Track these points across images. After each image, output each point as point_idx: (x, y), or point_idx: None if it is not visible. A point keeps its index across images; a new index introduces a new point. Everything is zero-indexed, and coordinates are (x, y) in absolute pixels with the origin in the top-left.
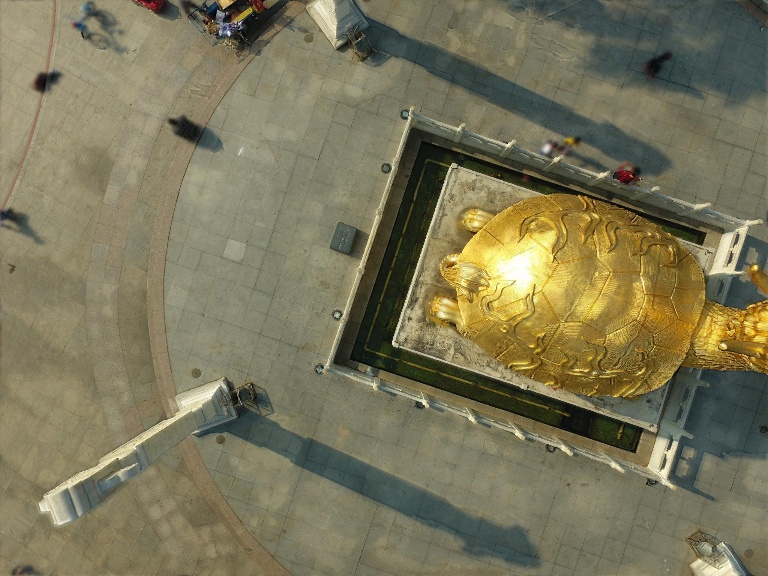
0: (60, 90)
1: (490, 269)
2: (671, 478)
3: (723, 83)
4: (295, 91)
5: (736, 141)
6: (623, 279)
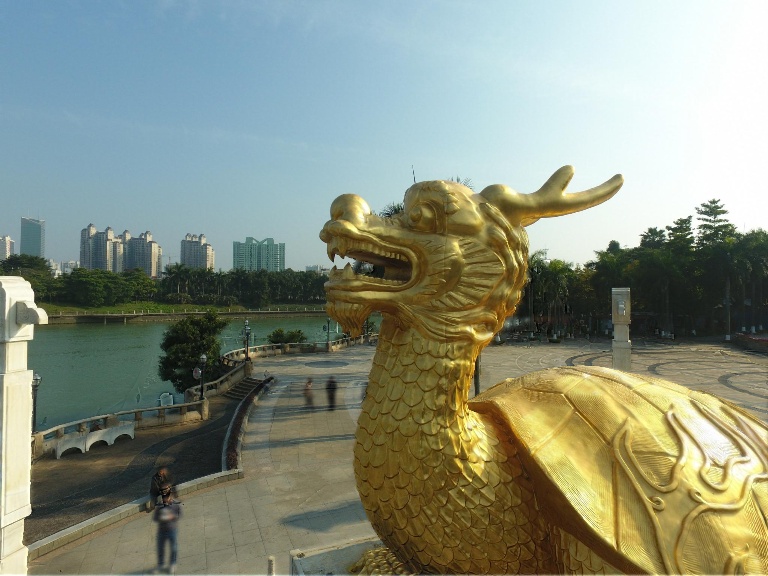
0: None
1: None
2: None
3: None
4: None
5: None
6: (633, 378)
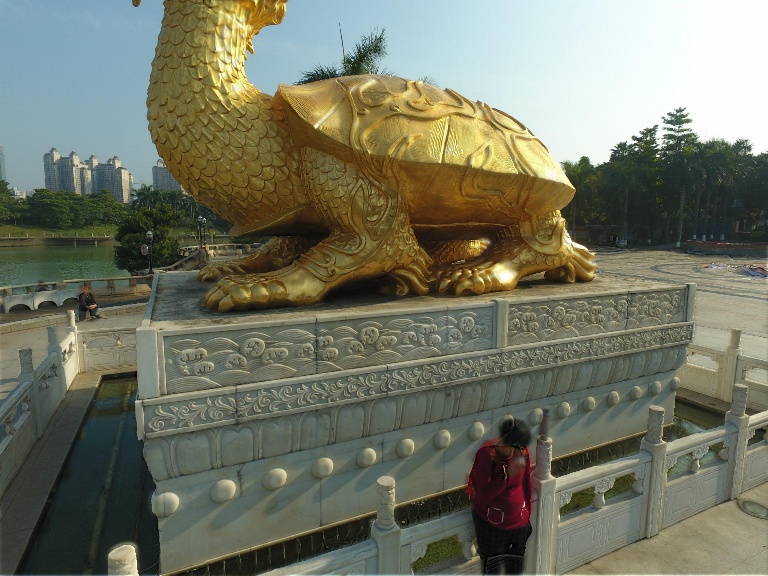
0: None
1: None
2: None
3: None
4: None
5: None
6: None
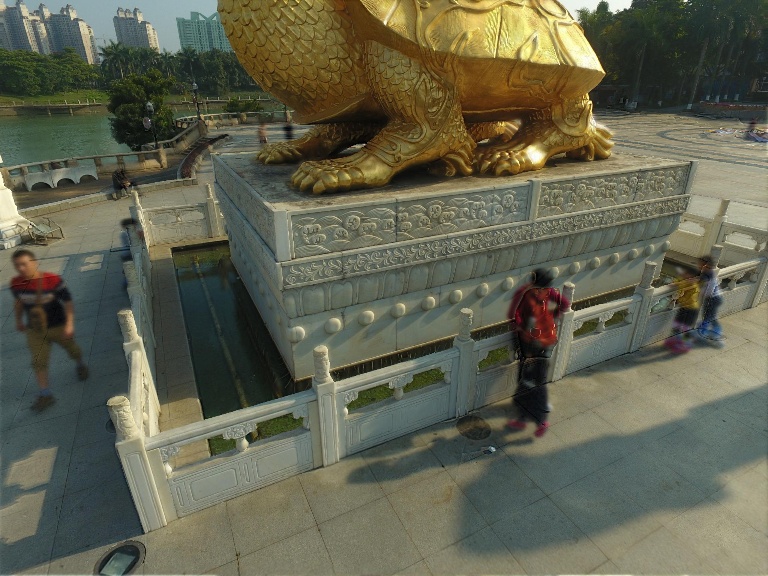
0: None
1: None
2: (108, 252)
3: None
4: None
5: None
6: None
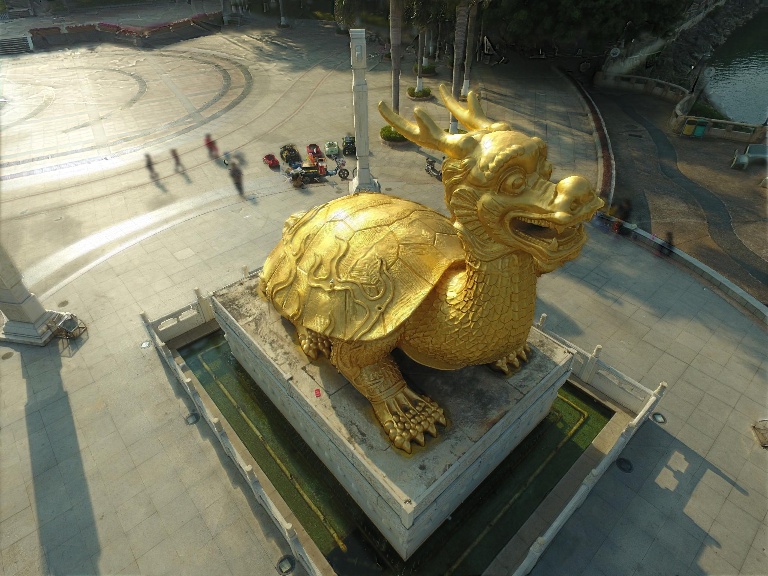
0: (190, 174)
1: None
2: None
3: (658, 307)
4: (309, 206)
5: (667, 349)
6: (398, 205)
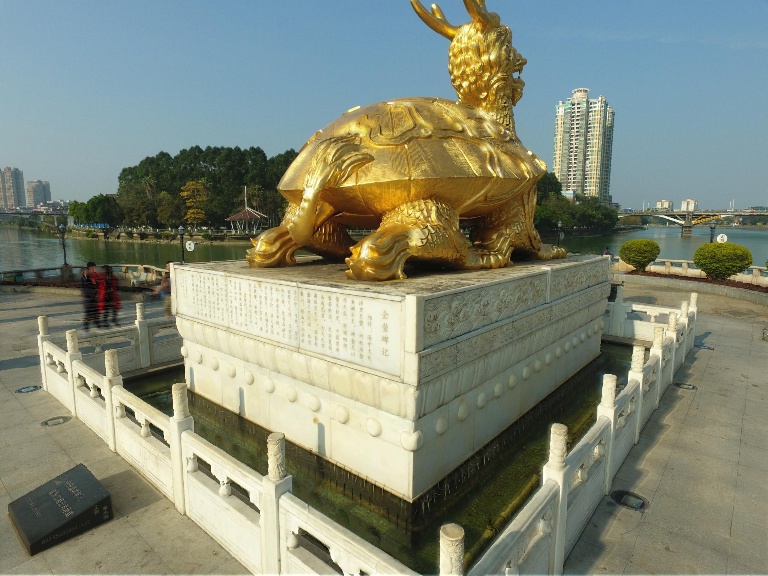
0: None
1: (336, 136)
2: None
3: None
4: None
5: None
6: None
